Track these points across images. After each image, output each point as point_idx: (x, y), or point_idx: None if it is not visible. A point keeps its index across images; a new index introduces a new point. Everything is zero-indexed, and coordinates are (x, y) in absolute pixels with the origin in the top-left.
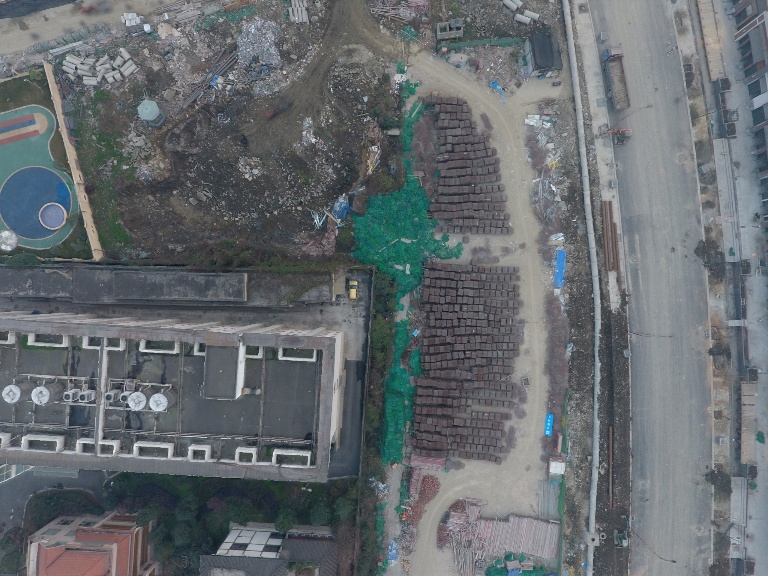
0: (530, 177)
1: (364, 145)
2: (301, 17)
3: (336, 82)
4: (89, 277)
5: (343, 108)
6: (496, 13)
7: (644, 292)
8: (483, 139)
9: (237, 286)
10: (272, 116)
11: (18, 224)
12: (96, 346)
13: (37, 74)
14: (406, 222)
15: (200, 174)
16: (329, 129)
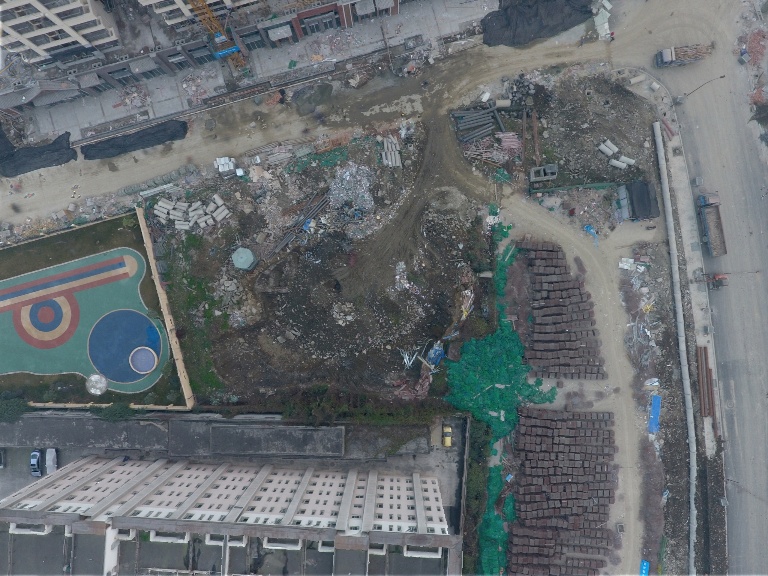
0: (624, 321)
1: (457, 288)
2: (394, 161)
3: (429, 226)
4: (185, 429)
5: (436, 252)
6: (591, 158)
7: (740, 438)
8: (578, 285)
9: (335, 441)
10: (365, 260)
11: (108, 368)
12: (218, 541)
13: (130, 222)
14: (501, 369)
15: (289, 313)
16: (422, 274)
